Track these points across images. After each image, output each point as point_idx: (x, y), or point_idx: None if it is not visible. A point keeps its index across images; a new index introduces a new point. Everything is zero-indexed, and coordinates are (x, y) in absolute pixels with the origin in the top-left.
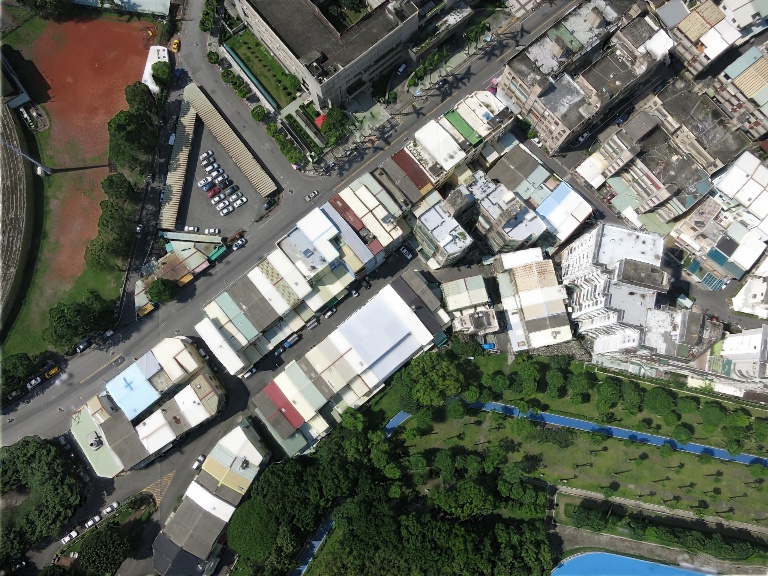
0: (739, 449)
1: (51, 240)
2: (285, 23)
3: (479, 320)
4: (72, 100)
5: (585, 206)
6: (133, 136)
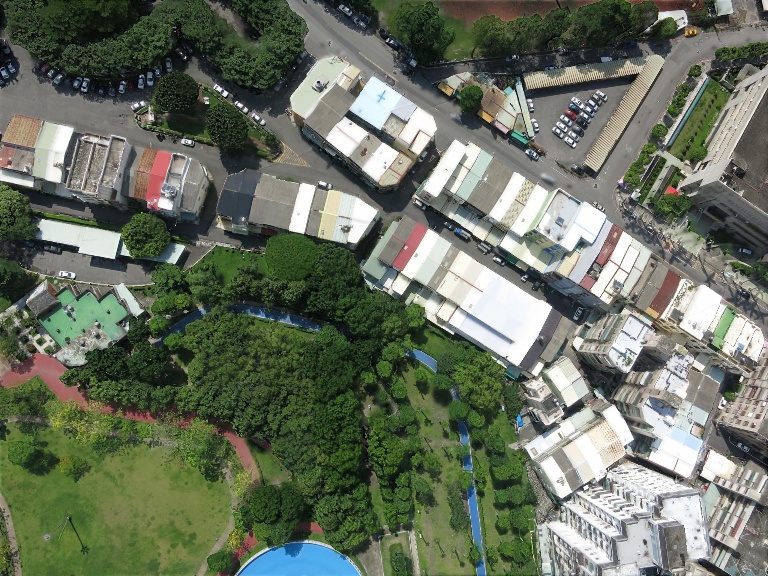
0: None
1: None
2: (760, 127)
3: (551, 404)
4: None
5: (689, 470)
6: (609, 23)
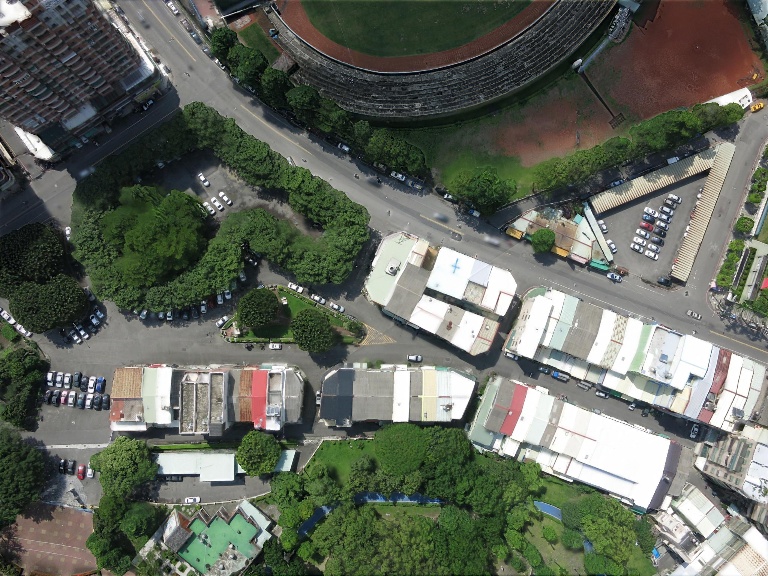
0: None
1: (522, 111)
2: None
3: (690, 544)
4: (653, 47)
5: None
6: (674, 137)
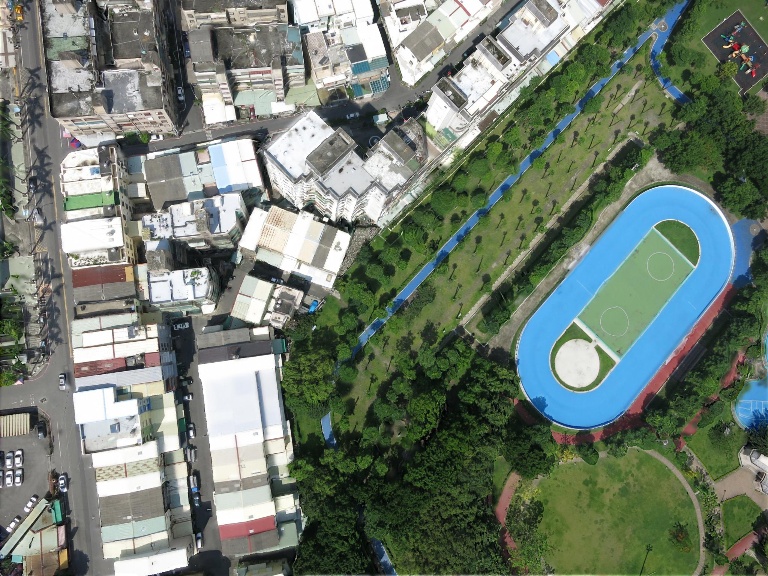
0: (516, 164)
1: None
2: None
3: (283, 306)
4: None
5: (243, 144)
6: None
